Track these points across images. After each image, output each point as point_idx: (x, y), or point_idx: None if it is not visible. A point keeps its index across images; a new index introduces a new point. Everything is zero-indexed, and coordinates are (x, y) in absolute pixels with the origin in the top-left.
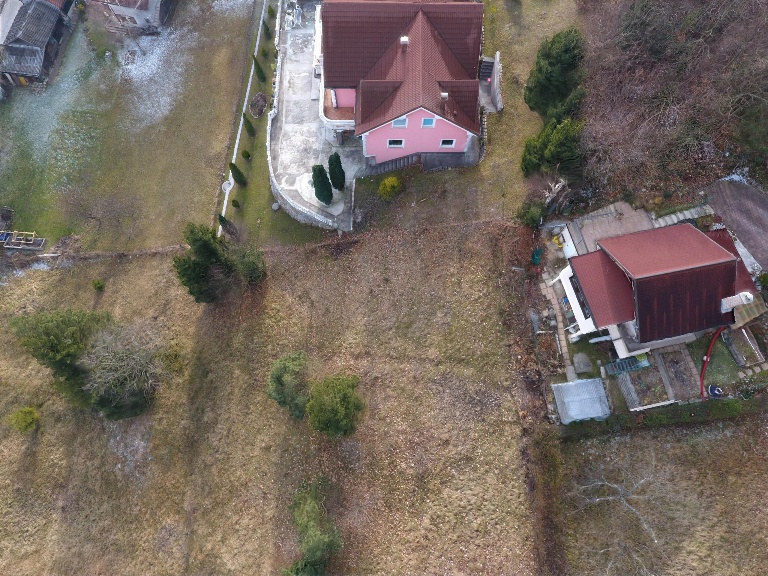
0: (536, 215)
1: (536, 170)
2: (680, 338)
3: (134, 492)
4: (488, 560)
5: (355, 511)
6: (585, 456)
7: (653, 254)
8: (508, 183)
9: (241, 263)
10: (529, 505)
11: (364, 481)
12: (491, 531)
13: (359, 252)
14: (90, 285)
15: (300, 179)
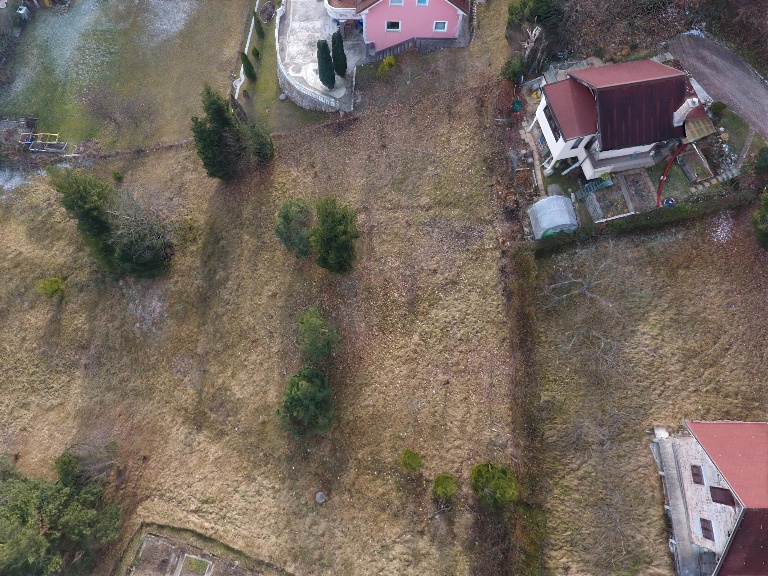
0: (516, 66)
1: (518, 31)
2: (641, 163)
3: (151, 345)
4: (469, 363)
5: (352, 338)
6: (556, 268)
7: (614, 75)
8: (494, 56)
9: (251, 137)
10: (506, 313)
11: (361, 313)
12: (472, 339)
13: (359, 128)
14: (110, 178)
15: (306, 68)
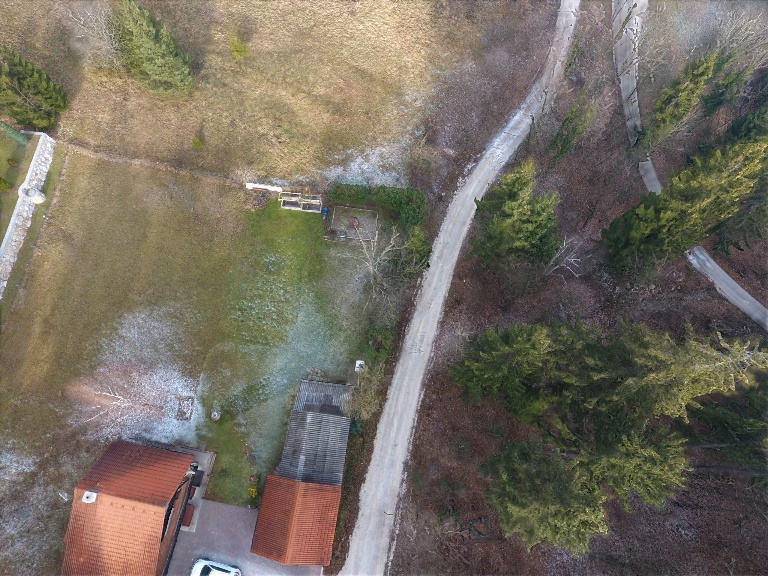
0: None
1: None
2: None
3: (143, 3)
4: None
5: None
6: None
7: None
8: None
9: None
10: None
11: None
12: None
13: None
14: (213, 150)
15: None
